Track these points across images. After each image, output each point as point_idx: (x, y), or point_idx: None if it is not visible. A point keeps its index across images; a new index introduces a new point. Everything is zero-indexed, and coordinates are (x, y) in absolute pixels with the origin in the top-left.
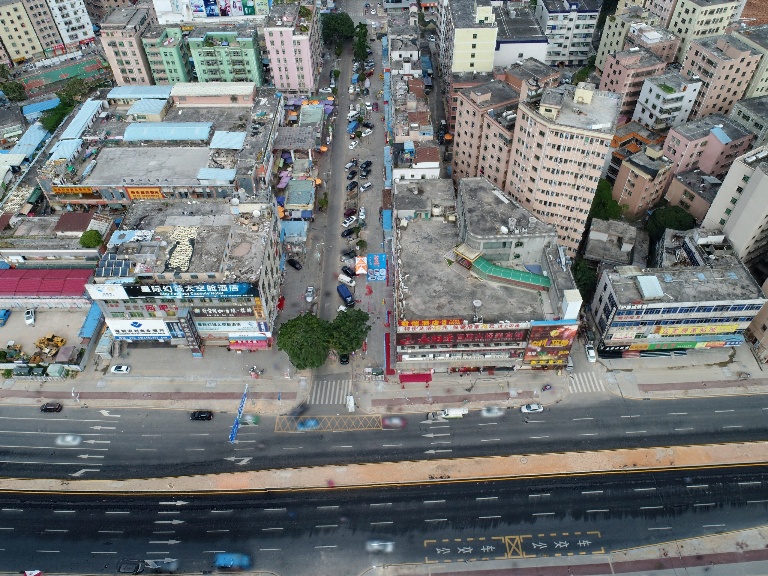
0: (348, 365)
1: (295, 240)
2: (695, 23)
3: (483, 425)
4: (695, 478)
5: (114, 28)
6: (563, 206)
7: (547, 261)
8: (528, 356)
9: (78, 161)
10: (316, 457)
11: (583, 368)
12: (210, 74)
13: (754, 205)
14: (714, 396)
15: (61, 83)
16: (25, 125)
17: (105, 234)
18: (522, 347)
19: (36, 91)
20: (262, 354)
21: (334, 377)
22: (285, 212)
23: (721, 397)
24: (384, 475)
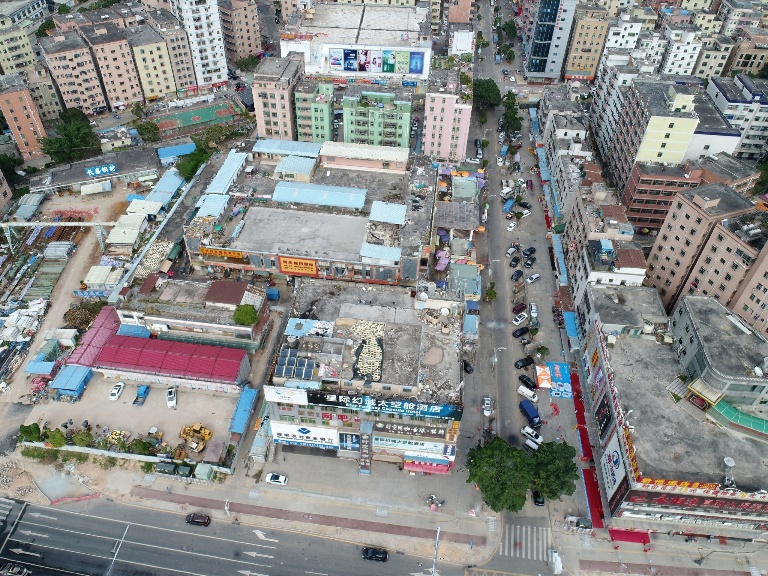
0: (544, 507)
1: (466, 338)
2: None
3: None
4: None
5: (268, 79)
6: None
7: None
8: None
9: (224, 219)
10: None
11: None
12: (358, 134)
13: None
14: None
15: (195, 127)
16: (159, 169)
17: (259, 309)
18: None
19: (168, 132)
20: (439, 479)
21: (529, 521)
22: None
23: None
24: None
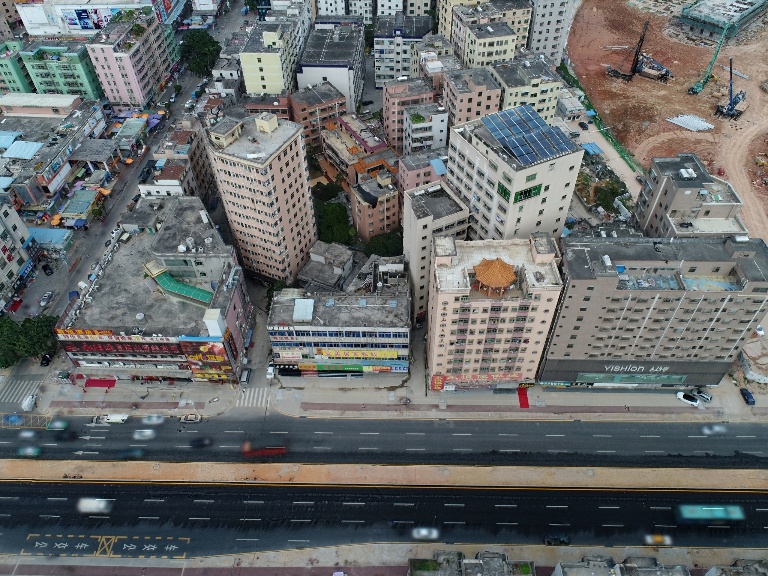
0: (47, 367)
1: (51, 247)
2: (476, 54)
3: (139, 431)
4: (305, 495)
5: None
6: (256, 228)
7: (219, 280)
8: (194, 369)
9: None
10: None
11: (259, 384)
12: (46, 85)
13: (412, 237)
14: (367, 418)
15: None
16: None
17: None
18: (185, 360)
19: None
20: None
21: (29, 377)
22: (62, 220)
23: (374, 420)
24: (24, 471)
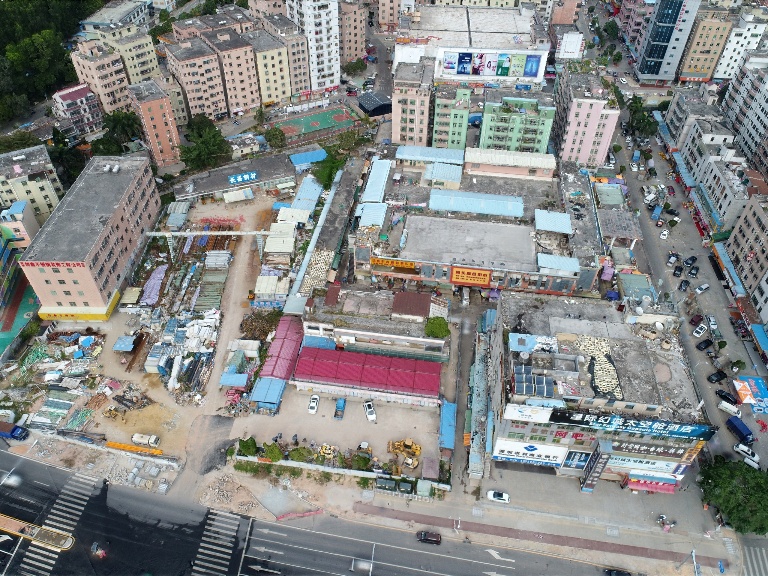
0: None
1: None
2: None
3: None
4: None
5: (409, 85)
6: None
7: None
8: None
9: (385, 228)
10: None
11: None
12: (496, 140)
13: None
14: None
15: (319, 132)
16: None
17: None
18: None
19: None
20: (664, 498)
21: (767, 544)
22: None
23: None
24: None
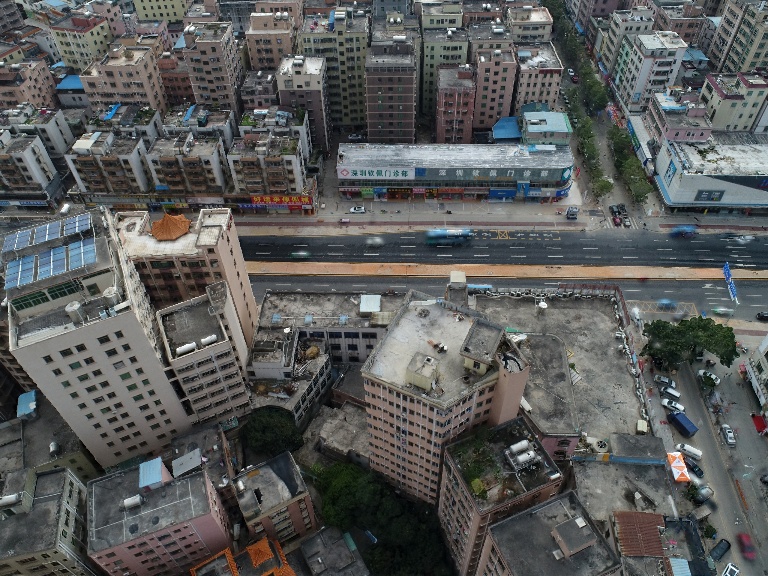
0: None
1: None
2: None
3: None
4: (370, 258)
5: None
6: None
7: None
8: None
9: None
10: (651, 285)
11: None
12: None
13: None
14: None
15: None
16: None
17: None
18: None
19: None
20: None
21: None
22: None
23: None
24: (595, 270)
